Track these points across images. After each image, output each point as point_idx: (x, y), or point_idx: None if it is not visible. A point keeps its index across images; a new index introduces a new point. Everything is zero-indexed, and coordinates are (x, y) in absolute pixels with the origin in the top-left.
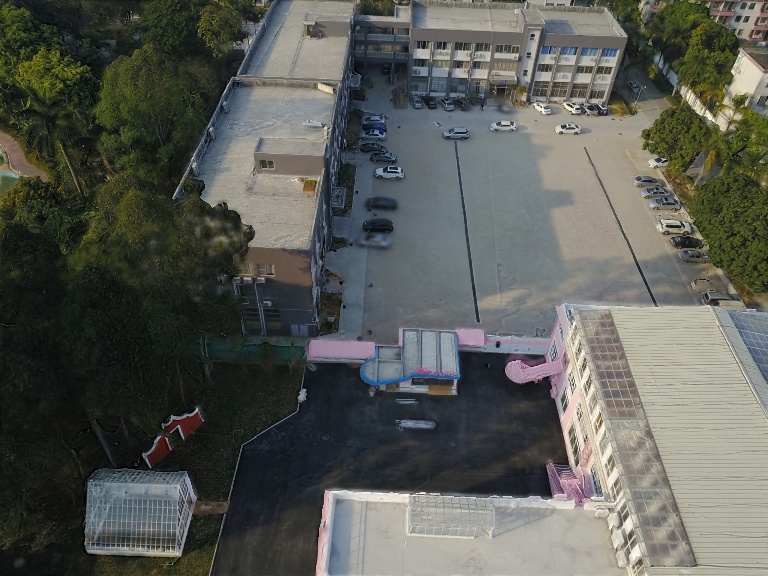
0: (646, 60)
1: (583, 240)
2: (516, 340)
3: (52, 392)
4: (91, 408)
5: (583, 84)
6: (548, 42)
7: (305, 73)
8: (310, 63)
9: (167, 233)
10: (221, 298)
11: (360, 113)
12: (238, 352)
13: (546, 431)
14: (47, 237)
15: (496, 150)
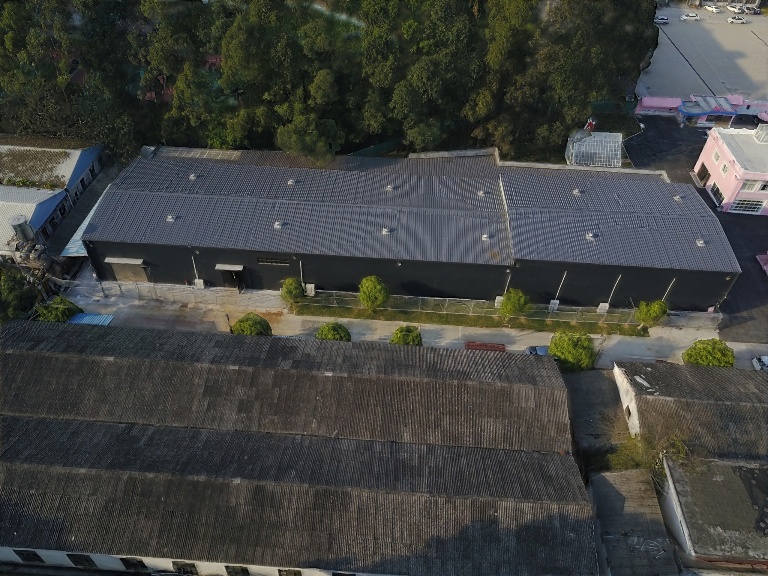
0: None
1: None
2: (760, 104)
3: None
4: (626, 61)
5: None
6: None
7: None
8: None
9: None
10: None
11: None
12: (597, 105)
13: None
14: None
15: (690, 30)
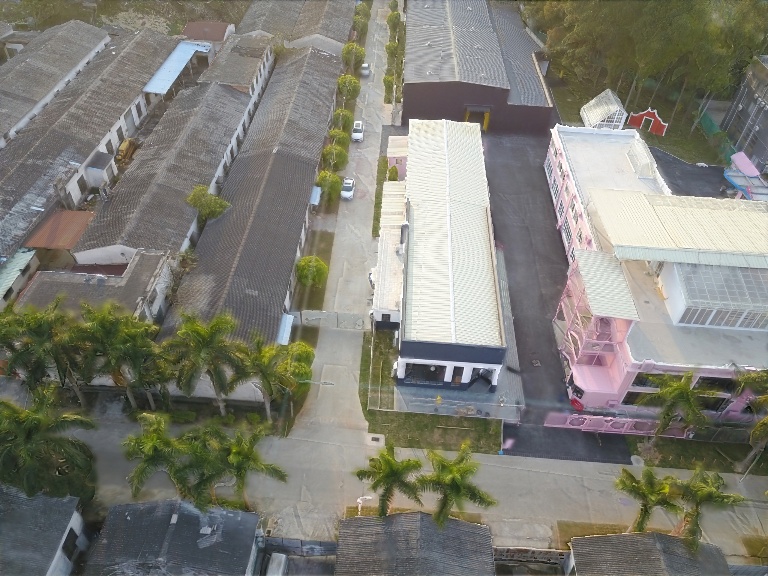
0: None
1: None
2: None
3: (631, 6)
4: None
5: None
6: None
7: None
8: None
9: None
10: (720, 55)
11: None
12: None
13: None
14: None
15: None
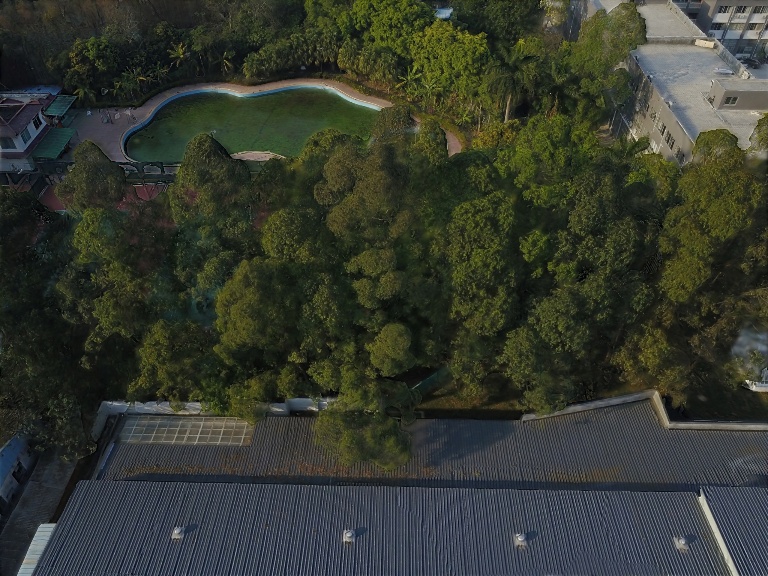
0: None
1: None
2: None
3: None
4: None
5: None
6: None
7: (661, 34)
8: (656, 26)
9: None
10: None
11: None
12: None
13: None
14: None
15: None
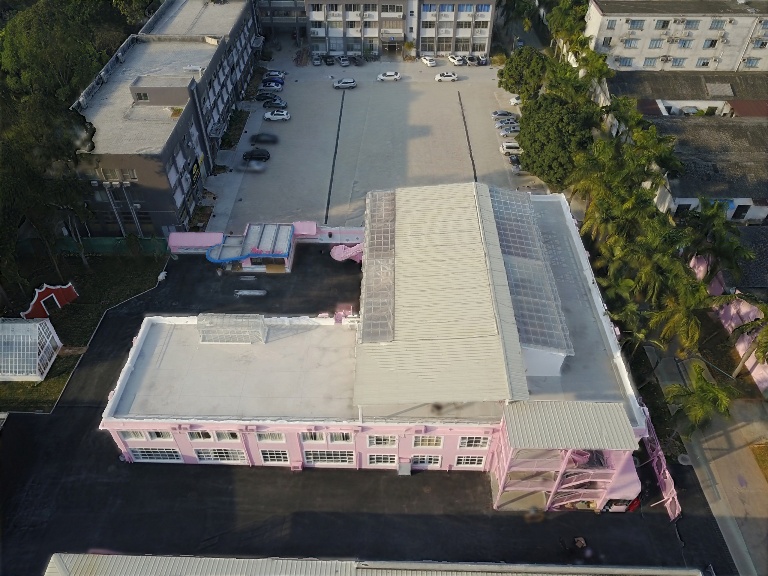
0: (521, 15)
1: (434, 162)
2: (344, 230)
3: None
4: None
5: (465, 38)
6: (427, 0)
7: (201, 31)
8: (207, 24)
9: (4, 115)
10: None
11: (263, 70)
12: (113, 246)
13: (356, 295)
14: None
15: (378, 96)
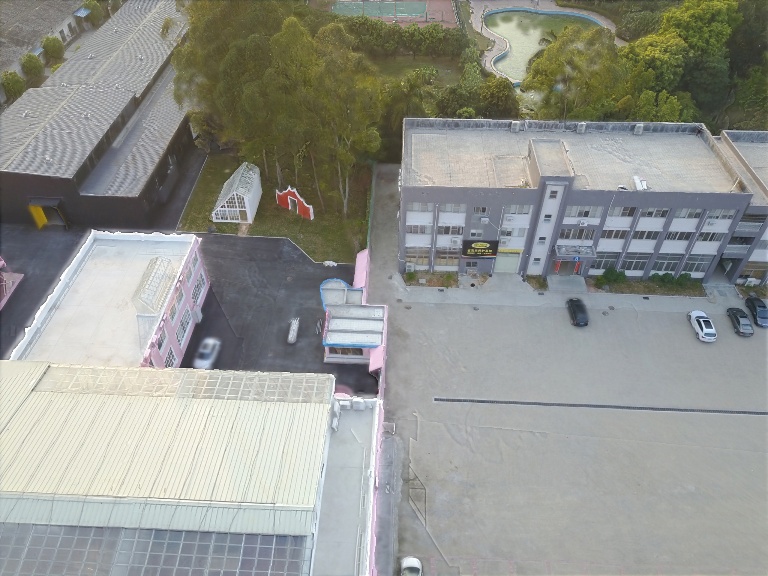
0: None
1: (643, 567)
2: None
3: (207, 68)
4: None
5: None
6: None
7: None
8: None
9: (287, 50)
10: (310, 130)
11: None
12: None
13: None
14: (273, 15)
15: None
